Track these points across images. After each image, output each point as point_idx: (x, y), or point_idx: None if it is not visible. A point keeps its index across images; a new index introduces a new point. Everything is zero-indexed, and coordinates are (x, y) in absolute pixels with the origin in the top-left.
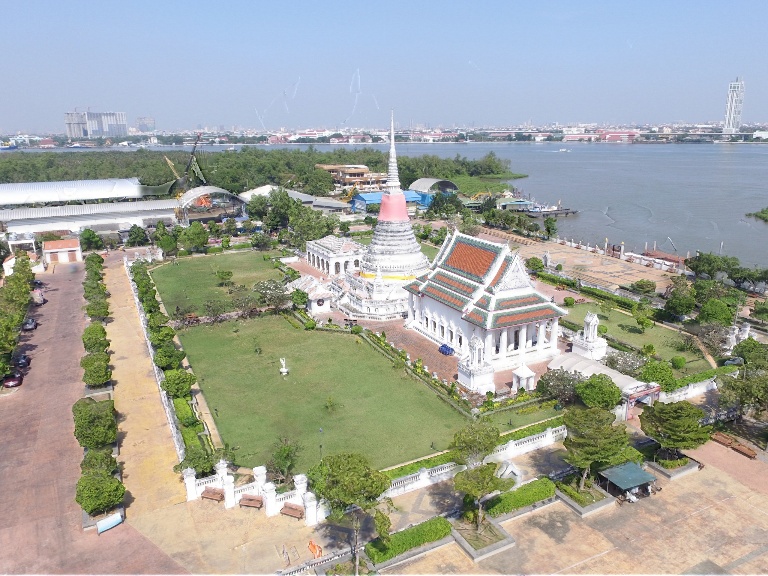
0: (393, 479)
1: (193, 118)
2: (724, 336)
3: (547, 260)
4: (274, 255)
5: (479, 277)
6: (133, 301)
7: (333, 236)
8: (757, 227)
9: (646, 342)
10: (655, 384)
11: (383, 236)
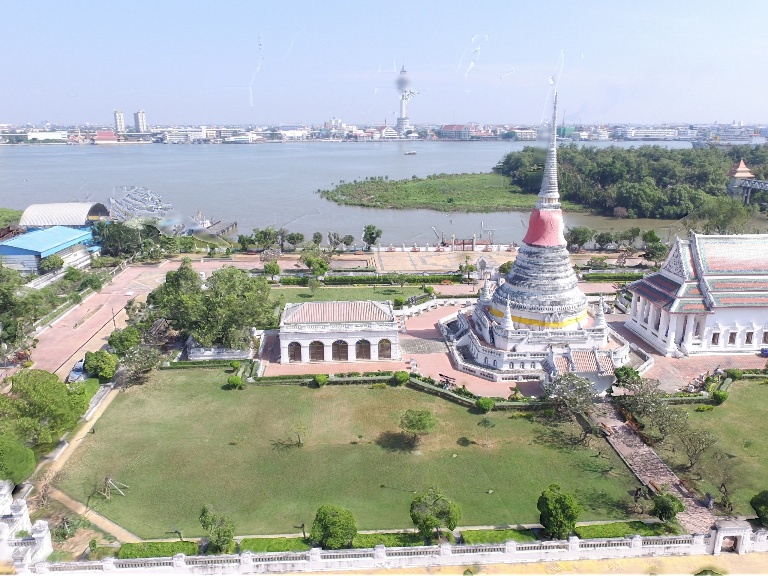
0: None
1: (514, 87)
2: None
3: (486, 264)
4: (199, 377)
5: None
6: (504, 567)
7: (321, 302)
8: (424, 210)
9: None
10: None
11: (563, 266)
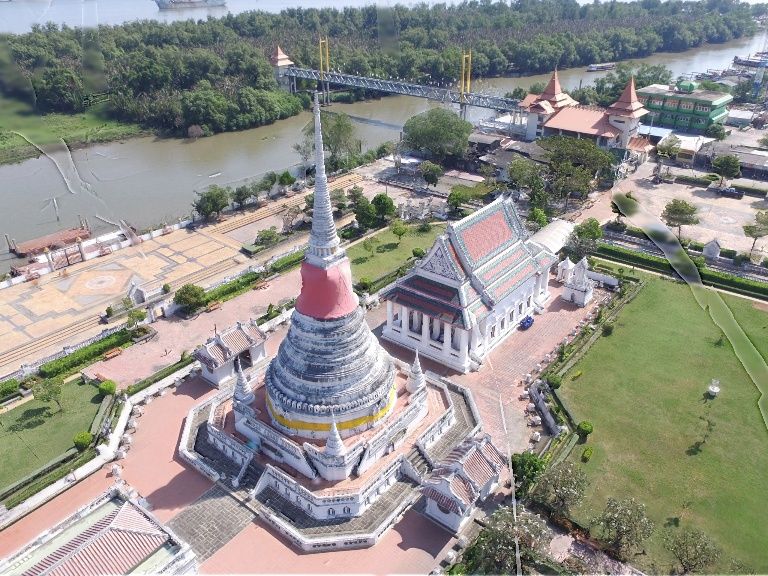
0: (759, 282)
1: None
2: (387, 217)
3: (143, 293)
4: None
5: (513, 238)
6: None
7: None
8: None
9: (419, 242)
10: (556, 218)
11: None
